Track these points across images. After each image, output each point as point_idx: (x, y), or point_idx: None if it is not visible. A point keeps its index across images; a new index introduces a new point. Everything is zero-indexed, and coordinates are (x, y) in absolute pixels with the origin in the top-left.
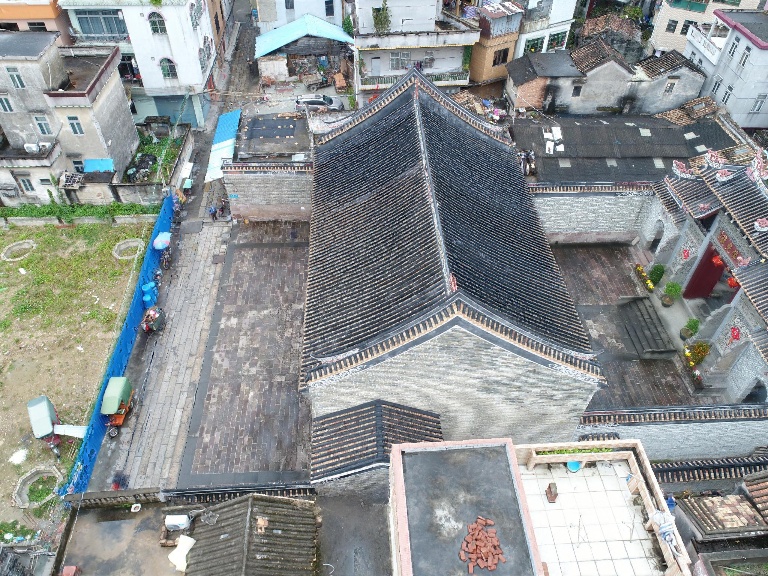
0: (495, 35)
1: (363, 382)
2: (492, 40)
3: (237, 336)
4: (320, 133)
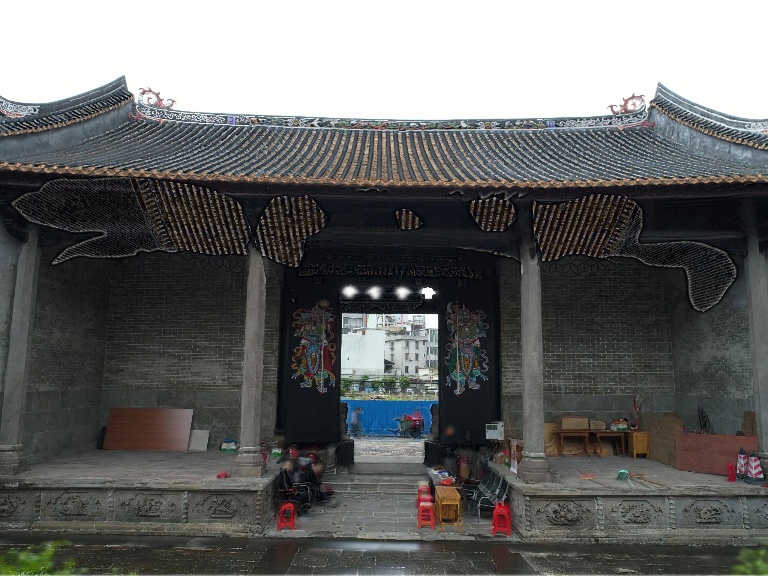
0: None
1: (145, 241)
2: None
3: (394, 444)
4: None
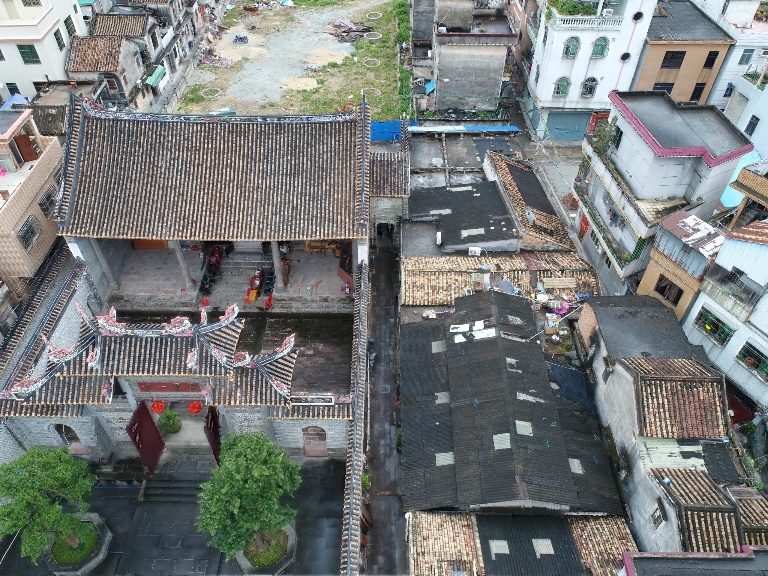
0: (662, 250)
1: None
2: (659, 254)
3: None
4: (485, 173)
